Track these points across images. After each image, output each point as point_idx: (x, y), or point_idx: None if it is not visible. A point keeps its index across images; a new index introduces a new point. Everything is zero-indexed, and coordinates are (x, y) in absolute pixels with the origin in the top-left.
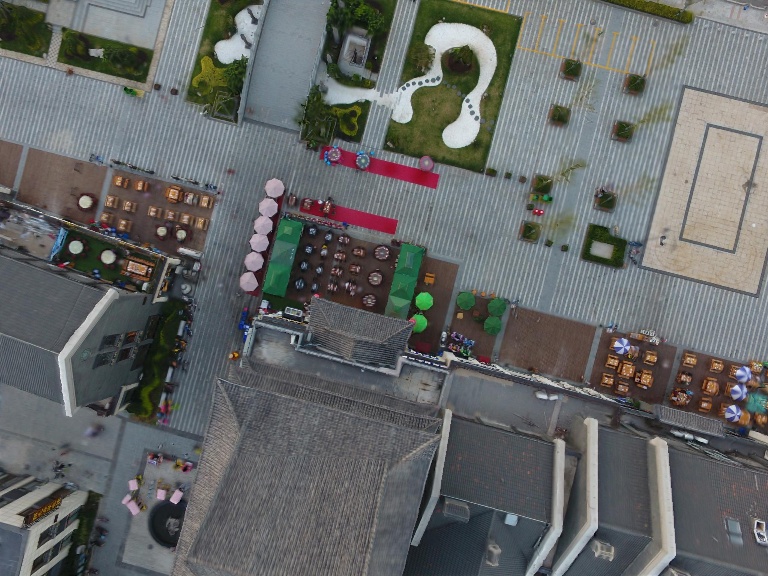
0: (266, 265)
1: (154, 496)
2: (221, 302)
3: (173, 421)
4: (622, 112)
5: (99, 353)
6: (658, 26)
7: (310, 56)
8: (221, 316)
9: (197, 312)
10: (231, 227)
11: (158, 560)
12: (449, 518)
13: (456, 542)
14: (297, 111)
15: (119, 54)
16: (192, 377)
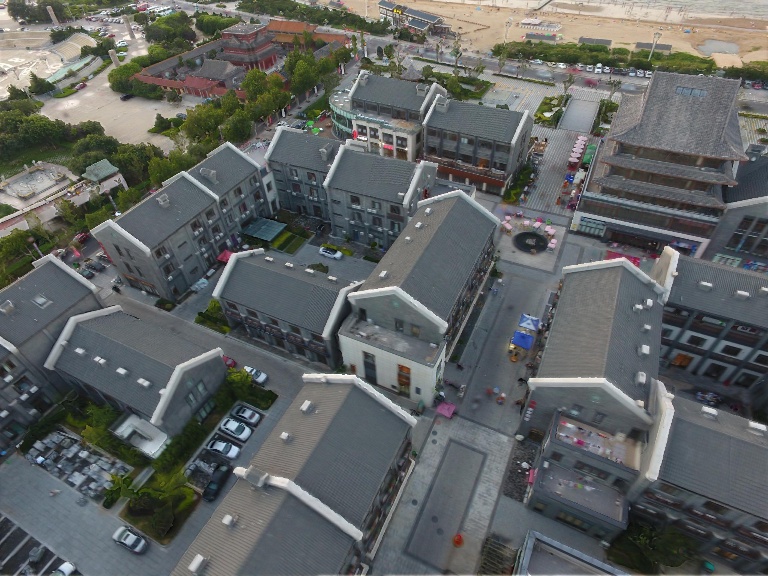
0: (581, 159)
1: (517, 230)
2: (554, 171)
3: (528, 205)
4: (759, 138)
5: (524, 134)
6: (762, 121)
7: (592, 114)
8: (554, 175)
9: (540, 173)
10: (556, 152)
11: (519, 258)
12: (749, 169)
13: (759, 175)
14: (587, 127)
15: (505, 105)
16: (539, 192)
